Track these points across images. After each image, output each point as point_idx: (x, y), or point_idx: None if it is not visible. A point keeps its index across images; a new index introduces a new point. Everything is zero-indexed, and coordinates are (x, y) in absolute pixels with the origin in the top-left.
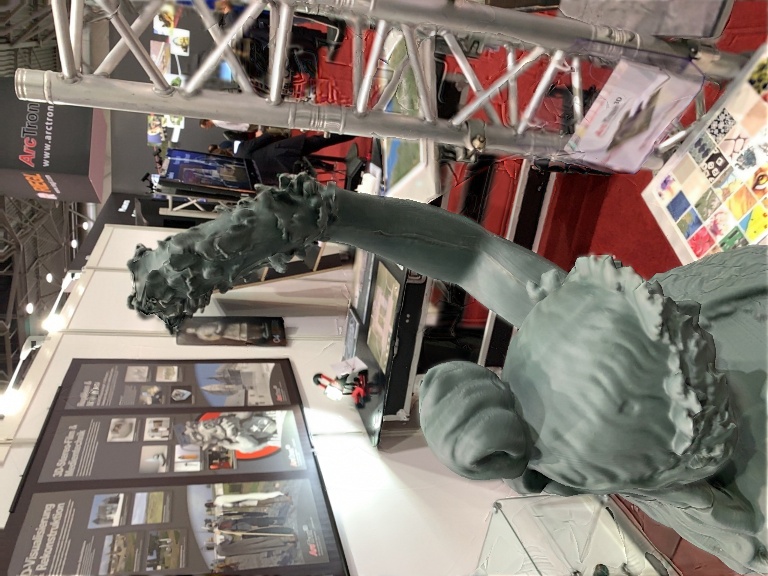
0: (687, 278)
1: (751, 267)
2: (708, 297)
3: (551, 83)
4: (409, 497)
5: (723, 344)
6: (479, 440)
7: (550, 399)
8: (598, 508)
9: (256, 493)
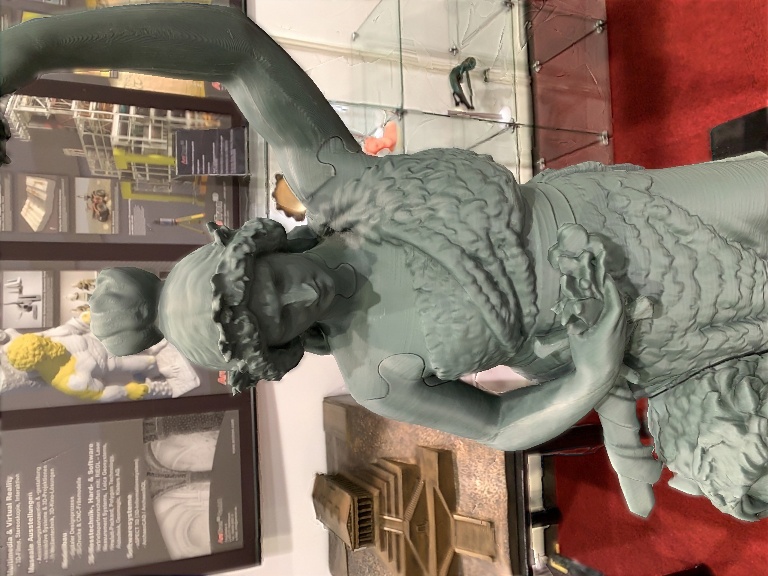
0: (395, 195)
1: (436, 220)
2: (389, 228)
3: None
4: None
5: (378, 261)
6: (112, 351)
7: (170, 338)
8: (497, 12)
9: None
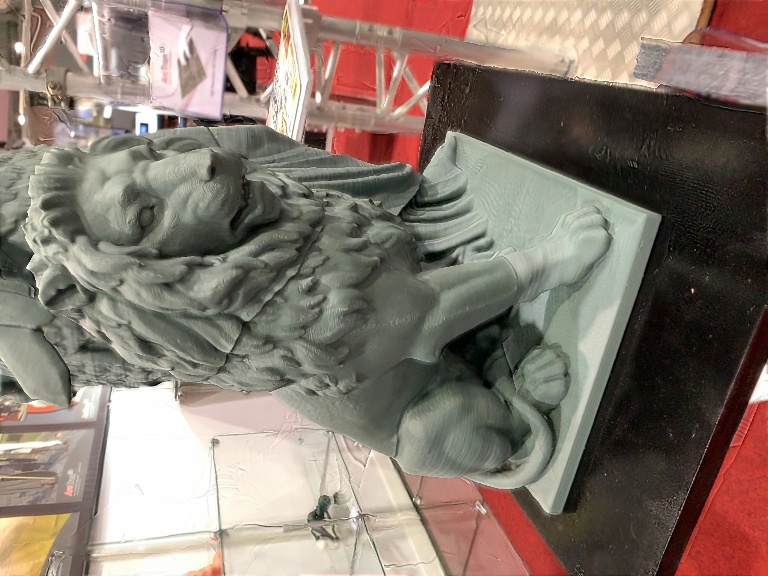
0: None
1: None
2: None
3: (101, 33)
4: (192, 445)
5: None
6: None
7: None
8: (327, 445)
9: (33, 442)
